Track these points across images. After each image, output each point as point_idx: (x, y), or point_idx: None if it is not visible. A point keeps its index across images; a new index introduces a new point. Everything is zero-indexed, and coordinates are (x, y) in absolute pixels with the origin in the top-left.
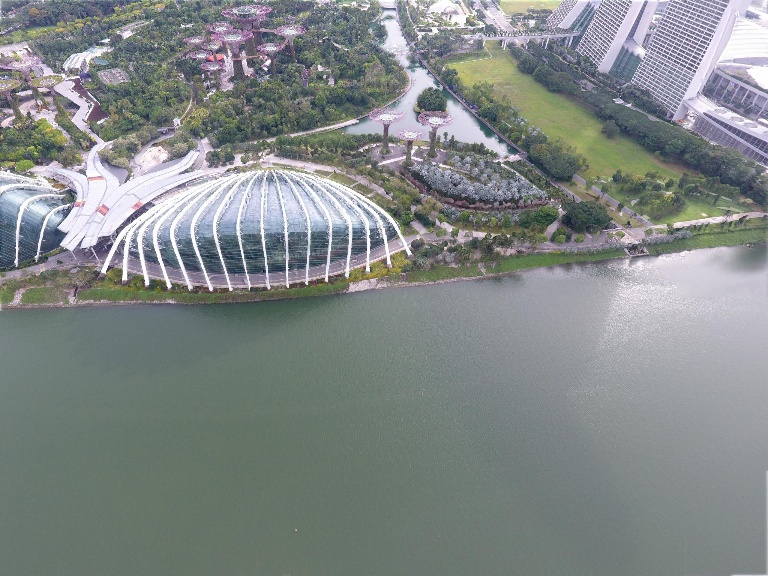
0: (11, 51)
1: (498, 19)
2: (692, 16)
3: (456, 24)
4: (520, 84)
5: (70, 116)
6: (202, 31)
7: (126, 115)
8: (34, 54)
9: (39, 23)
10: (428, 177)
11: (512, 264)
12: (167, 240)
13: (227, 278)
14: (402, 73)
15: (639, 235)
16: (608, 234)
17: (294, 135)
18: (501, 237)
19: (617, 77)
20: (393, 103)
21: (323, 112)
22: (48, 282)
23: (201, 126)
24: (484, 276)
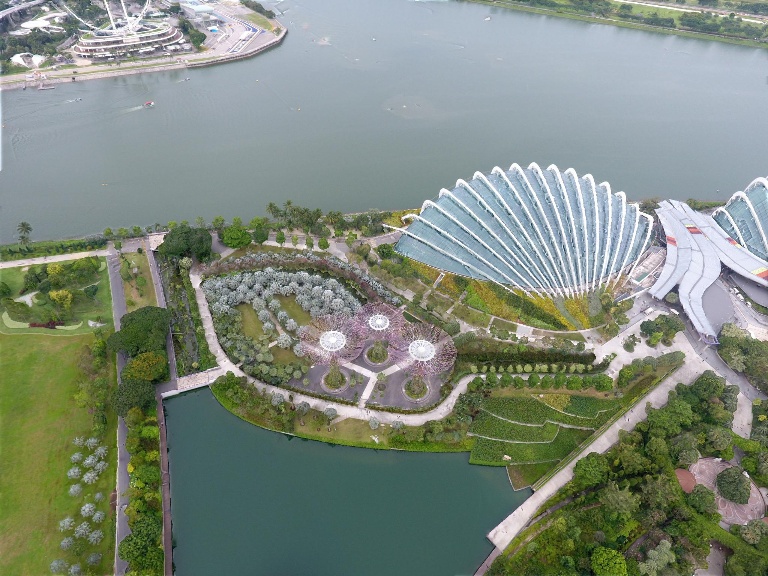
0: None
1: None
2: None
3: None
4: None
5: None
6: None
7: None
8: None
9: None
10: None
11: None
12: None
13: None
14: None
15: (139, 244)
16: None
17: (603, 443)
18: None
19: None
20: None
21: None
22: None
23: None
24: None
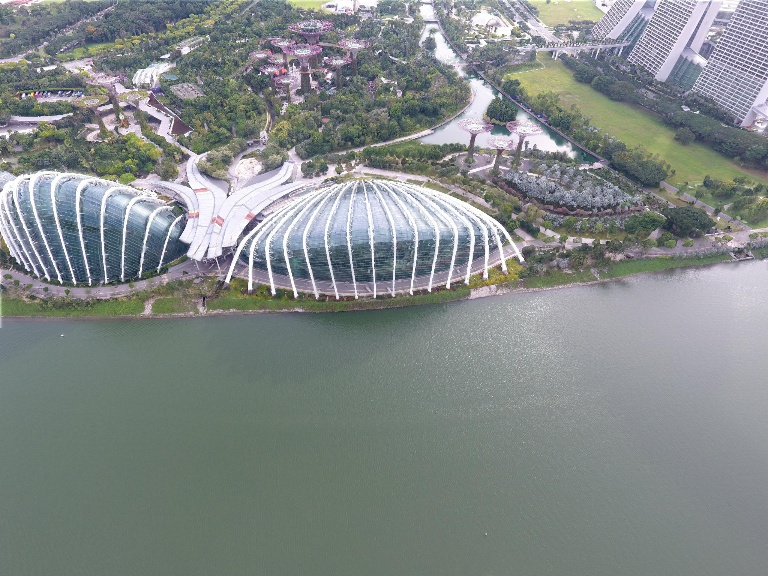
0: (75, 68)
1: (541, 30)
2: (761, 25)
3: (503, 36)
4: (581, 93)
5: (154, 130)
6: (257, 46)
7: (214, 128)
8: (99, 70)
9: (95, 40)
10: (522, 185)
11: (624, 269)
12: (297, 249)
13: (355, 286)
14: (465, 84)
15: (741, 239)
16: (716, 238)
17: None
18: (615, 242)
19: (675, 85)
20: (461, 113)
21: (398, 123)
22: (175, 292)
23: (287, 138)
24: (599, 281)
